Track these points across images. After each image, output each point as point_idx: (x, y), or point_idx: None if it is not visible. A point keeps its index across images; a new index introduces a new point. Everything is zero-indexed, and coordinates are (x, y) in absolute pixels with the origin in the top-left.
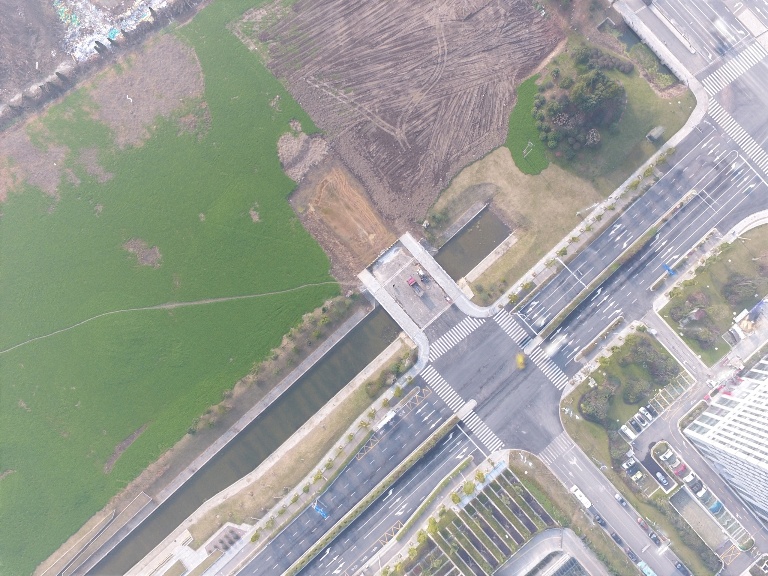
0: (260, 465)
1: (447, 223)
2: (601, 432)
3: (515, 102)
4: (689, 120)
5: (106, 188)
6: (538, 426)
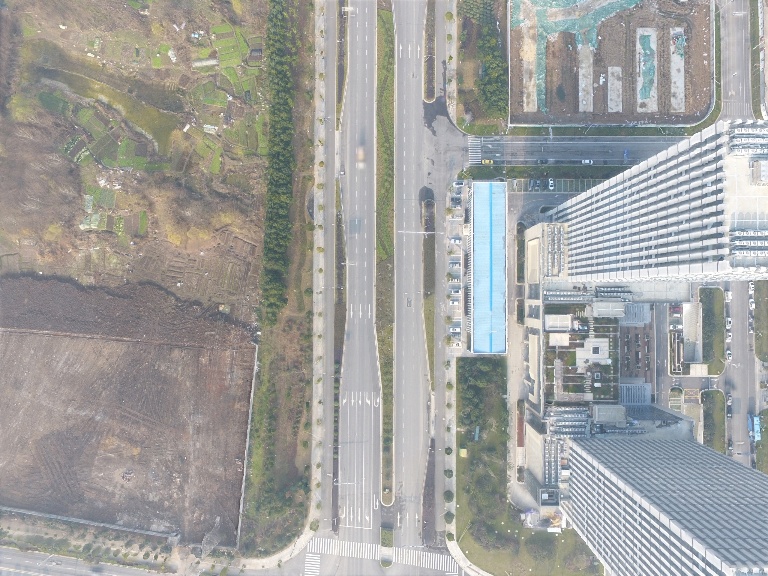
0: None
1: None
2: None
3: None
4: None
5: None
6: None
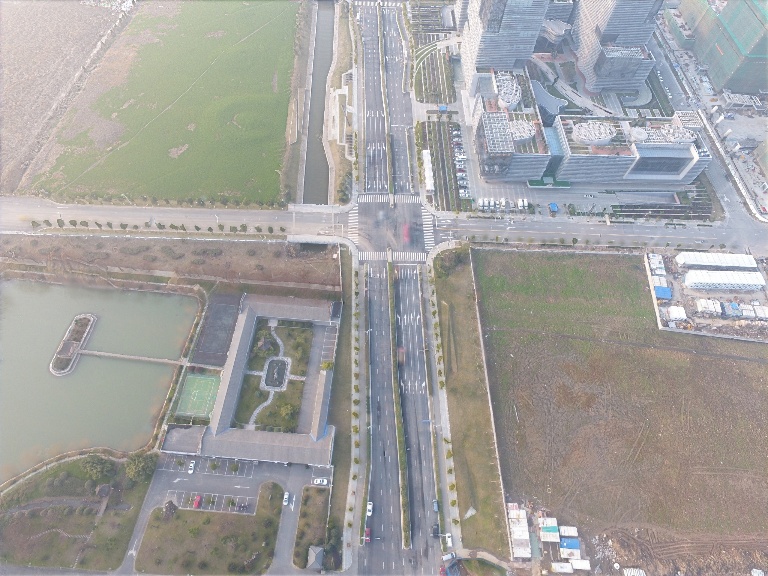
0: (333, 58)
1: None
2: None
3: None
4: None
5: (179, 29)
6: None
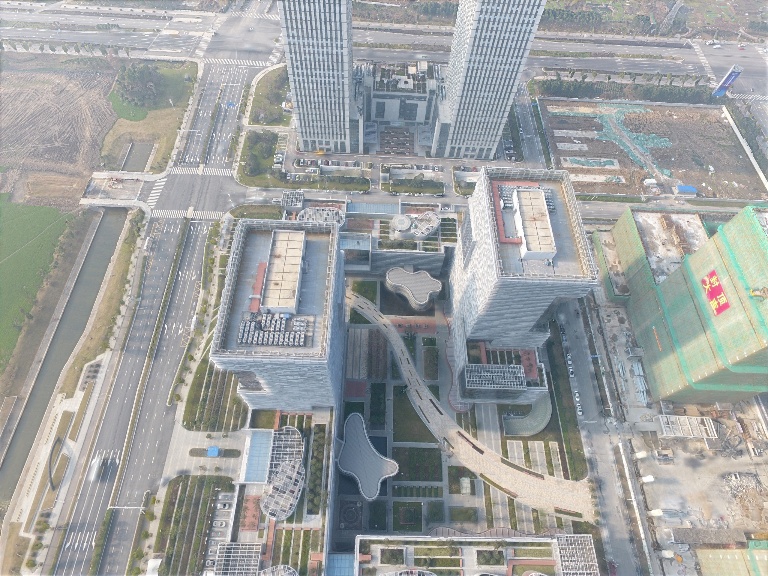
0: (87, 324)
1: (115, 159)
2: (265, 176)
3: (111, 103)
4: (199, 68)
5: None
6: (233, 194)
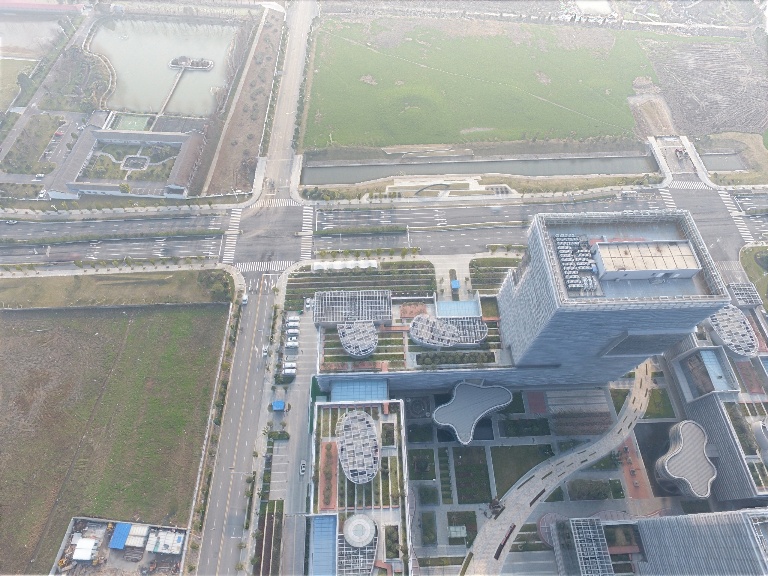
0: (539, 176)
1: (709, 146)
2: None
3: None
4: None
5: (542, 53)
6: (722, 249)
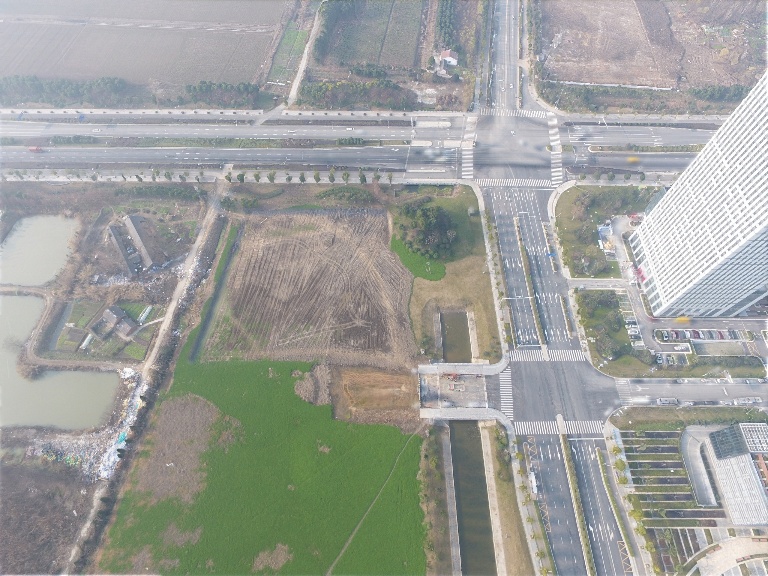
0: None
1: (432, 340)
2: (628, 358)
3: (397, 255)
4: (476, 195)
5: (203, 543)
6: (601, 391)
